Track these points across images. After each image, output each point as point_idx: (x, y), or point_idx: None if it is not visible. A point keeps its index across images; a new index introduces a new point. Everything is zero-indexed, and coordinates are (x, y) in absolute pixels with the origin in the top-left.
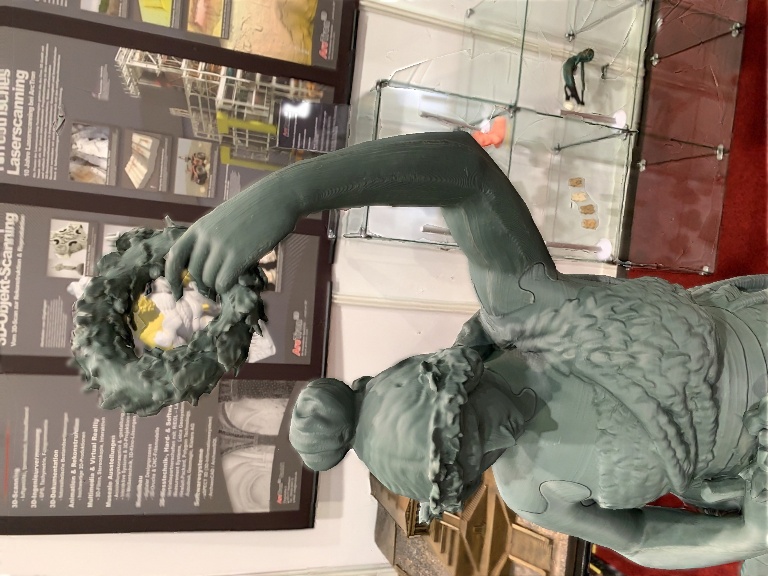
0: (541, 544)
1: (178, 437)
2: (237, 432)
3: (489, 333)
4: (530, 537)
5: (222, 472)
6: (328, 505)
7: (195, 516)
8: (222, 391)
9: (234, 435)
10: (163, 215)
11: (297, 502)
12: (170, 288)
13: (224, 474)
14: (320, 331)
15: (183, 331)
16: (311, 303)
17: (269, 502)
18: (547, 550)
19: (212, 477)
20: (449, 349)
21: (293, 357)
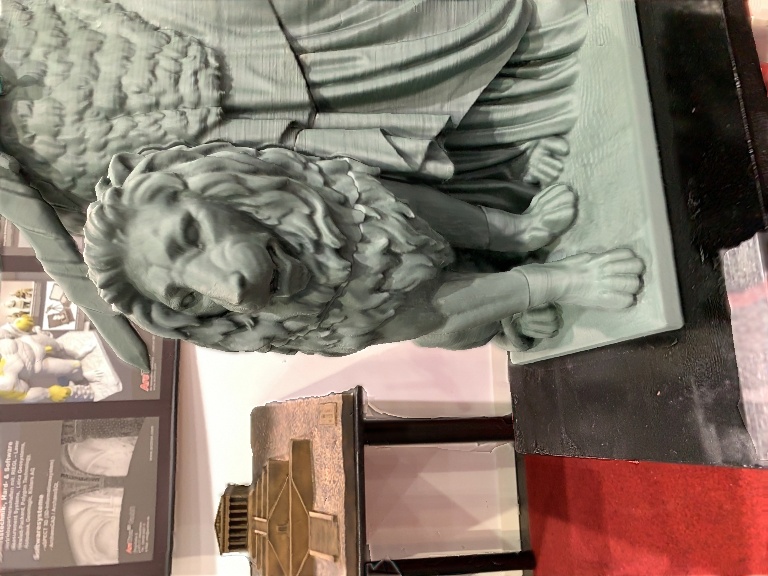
0: (330, 525)
1: (16, 483)
2: (81, 475)
3: None
4: (322, 521)
5: (62, 518)
6: (199, 561)
7: (34, 571)
8: (65, 432)
9: (78, 478)
10: (7, 267)
11: (150, 551)
12: (13, 334)
13: (65, 521)
14: (170, 364)
15: (25, 374)
16: (159, 338)
17: (118, 552)
18: (334, 530)
19: (52, 525)
20: None
21: (142, 393)
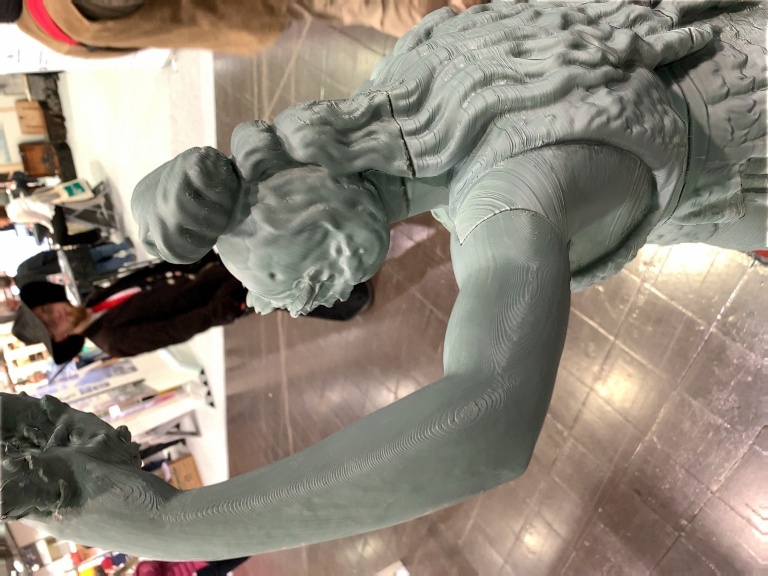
0: None
1: None
2: None
3: (458, 177)
4: None
5: None
6: None
7: None
8: None
9: None
10: None
11: None
12: None
13: None
14: None
15: None
16: None
17: None
18: None
19: None
20: (351, 272)
21: None
